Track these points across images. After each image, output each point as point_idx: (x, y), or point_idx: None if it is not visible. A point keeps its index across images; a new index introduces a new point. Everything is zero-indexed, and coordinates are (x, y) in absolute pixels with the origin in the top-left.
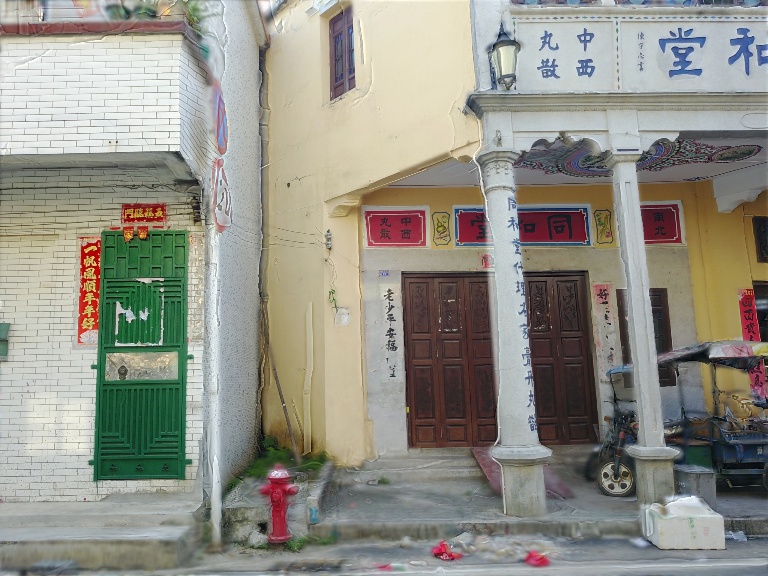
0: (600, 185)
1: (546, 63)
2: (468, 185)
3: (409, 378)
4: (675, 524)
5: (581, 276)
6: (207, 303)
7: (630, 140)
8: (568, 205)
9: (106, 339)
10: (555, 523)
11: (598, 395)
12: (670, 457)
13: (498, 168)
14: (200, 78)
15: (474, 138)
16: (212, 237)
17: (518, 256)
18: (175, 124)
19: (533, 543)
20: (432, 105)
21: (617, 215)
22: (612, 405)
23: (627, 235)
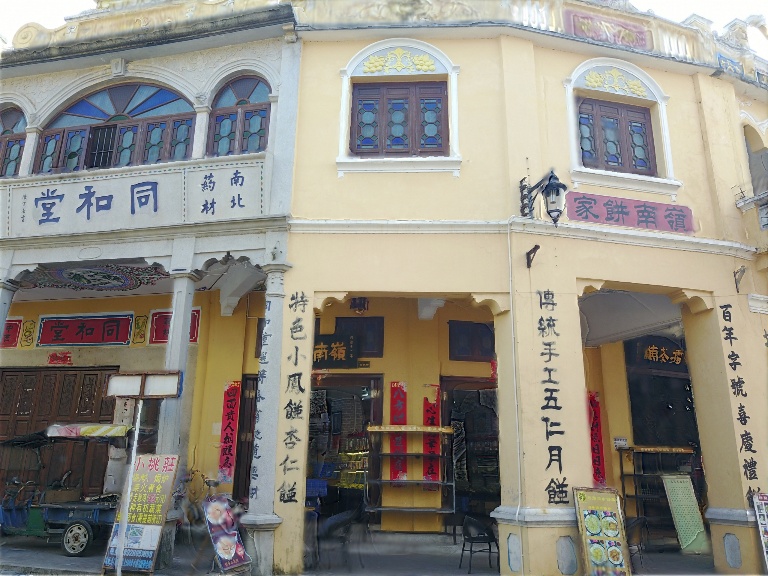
0: (142, 296)
1: None
2: (46, 300)
3: None
4: None
5: None
6: None
7: (2, 272)
8: (121, 312)
9: None
10: None
11: (106, 470)
12: None
13: None
14: None
15: None
16: None
17: None
18: None
19: None
20: None
21: None
22: (114, 479)
23: None
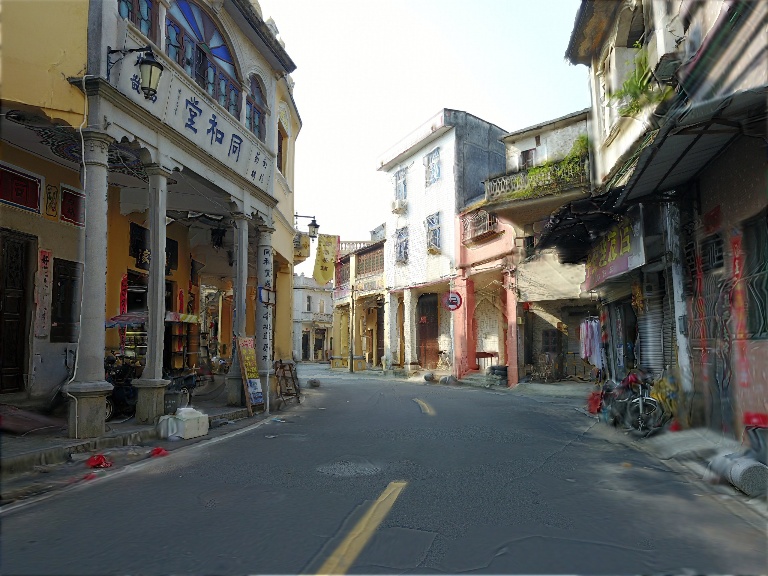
0: (55, 164)
1: (136, 78)
2: None
3: None
4: (193, 422)
5: (31, 240)
6: None
7: (167, 161)
8: (28, 172)
9: None
10: (120, 437)
11: (32, 348)
12: None
13: (103, 148)
14: None
15: (79, 110)
16: None
17: None
18: None
19: (134, 448)
20: (7, 42)
21: (151, 212)
22: (41, 357)
23: (160, 229)
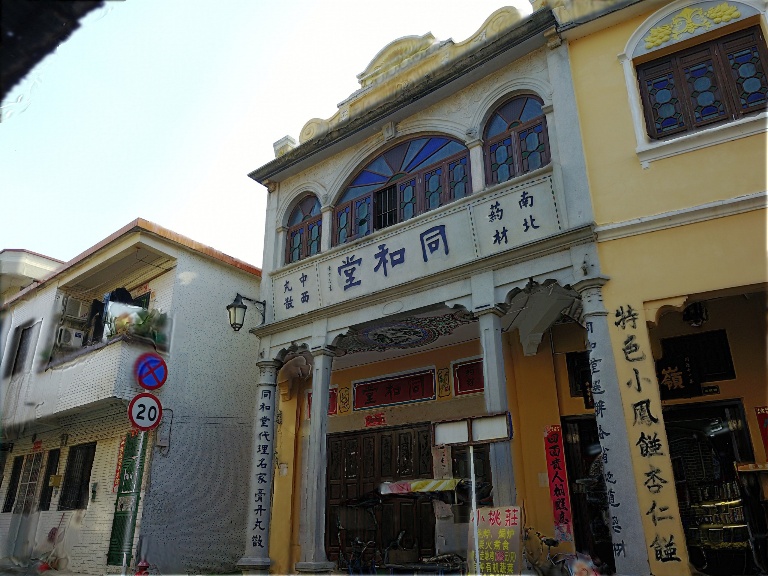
0: (440, 349)
1: (287, 300)
2: (355, 366)
3: (326, 514)
4: None
5: None
6: (153, 468)
7: (320, 340)
8: (422, 368)
9: (120, 489)
10: None
11: (435, 530)
12: (311, 570)
13: None
14: (128, 358)
15: None
16: (162, 431)
17: (263, 428)
18: (113, 384)
19: None
20: None
21: None
22: (444, 539)
23: (312, 407)
